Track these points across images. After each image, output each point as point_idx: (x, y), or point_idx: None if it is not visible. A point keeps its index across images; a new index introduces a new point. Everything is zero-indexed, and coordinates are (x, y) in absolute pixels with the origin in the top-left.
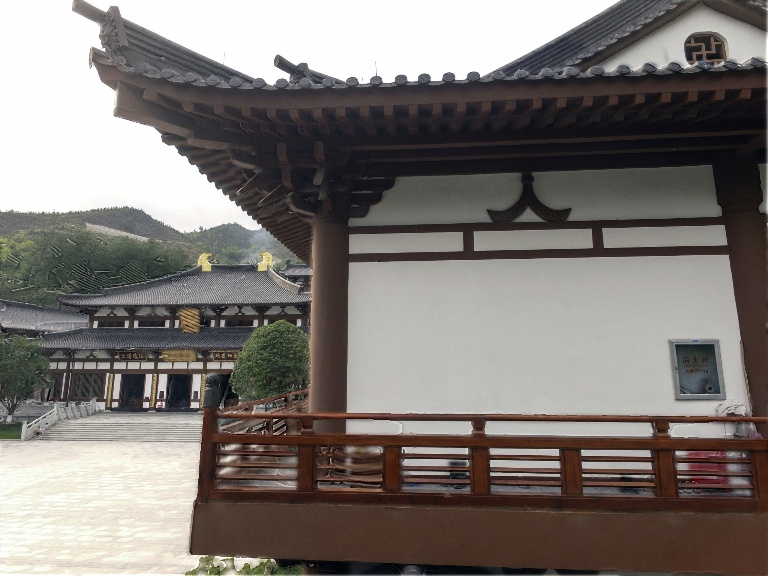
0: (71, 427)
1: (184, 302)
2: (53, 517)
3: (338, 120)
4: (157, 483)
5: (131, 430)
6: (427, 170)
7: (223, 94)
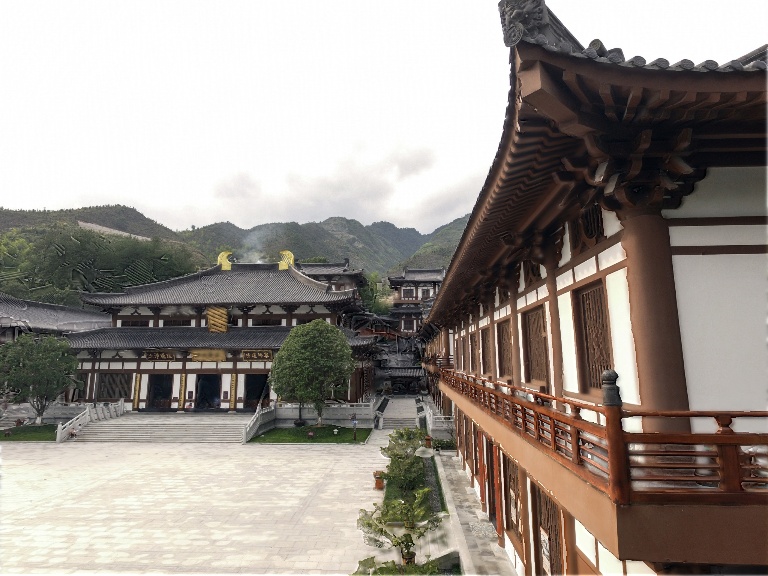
0: (105, 428)
1: (211, 301)
2: (135, 521)
3: (740, 105)
4: (223, 485)
5: (168, 431)
6: (745, 161)
7: (648, 76)
